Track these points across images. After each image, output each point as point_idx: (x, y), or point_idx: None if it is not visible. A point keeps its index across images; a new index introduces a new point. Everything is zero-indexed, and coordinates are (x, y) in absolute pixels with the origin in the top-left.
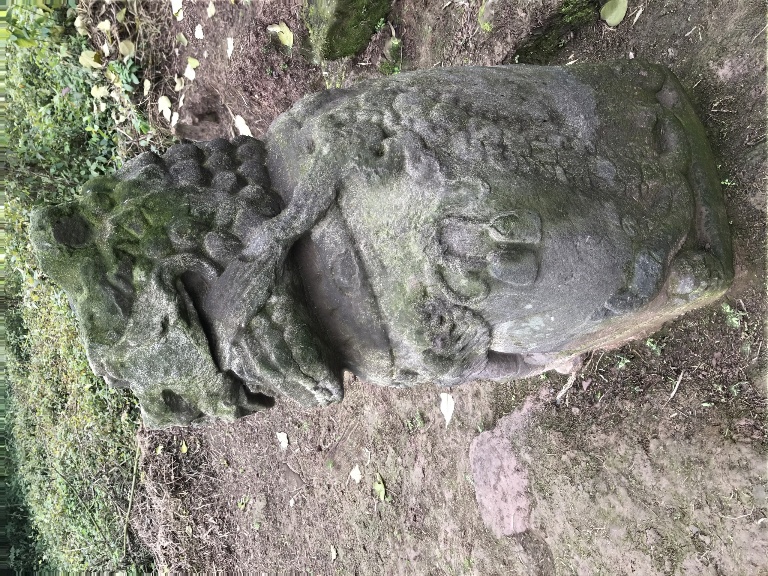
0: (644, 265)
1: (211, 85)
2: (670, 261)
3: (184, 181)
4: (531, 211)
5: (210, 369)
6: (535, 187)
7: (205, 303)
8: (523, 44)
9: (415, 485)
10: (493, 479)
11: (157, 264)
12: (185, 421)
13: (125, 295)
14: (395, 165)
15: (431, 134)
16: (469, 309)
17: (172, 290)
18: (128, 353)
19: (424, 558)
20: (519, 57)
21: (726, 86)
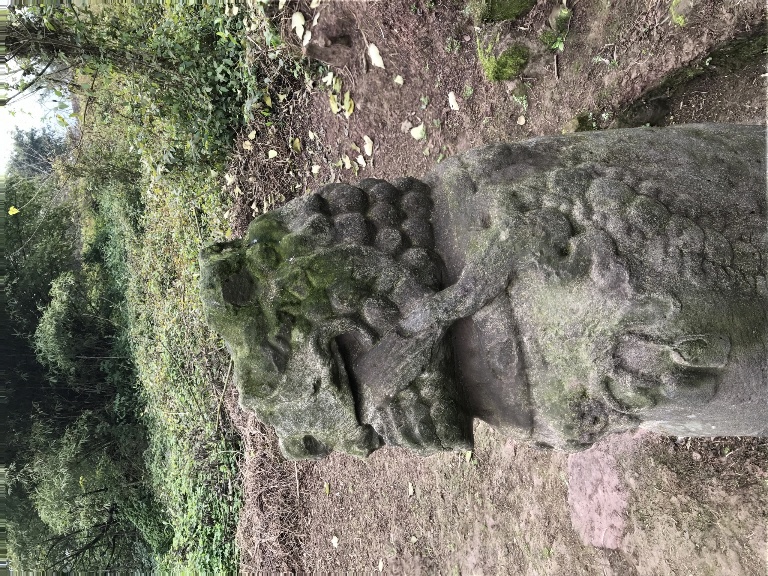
0: None
1: (349, 8)
2: None
3: (349, 238)
4: (722, 335)
5: (352, 424)
6: (731, 305)
7: (356, 366)
8: (720, 47)
9: (504, 460)
10: (590, 489)
11: (316, 327)
12: (320, 458)
13: (282, 353)
14: (580, 270)
15: (625, 237)
16: None
17: (327, 354)
18: (278, 405)
19: (502, 529)
20: (711, 60)
21: None
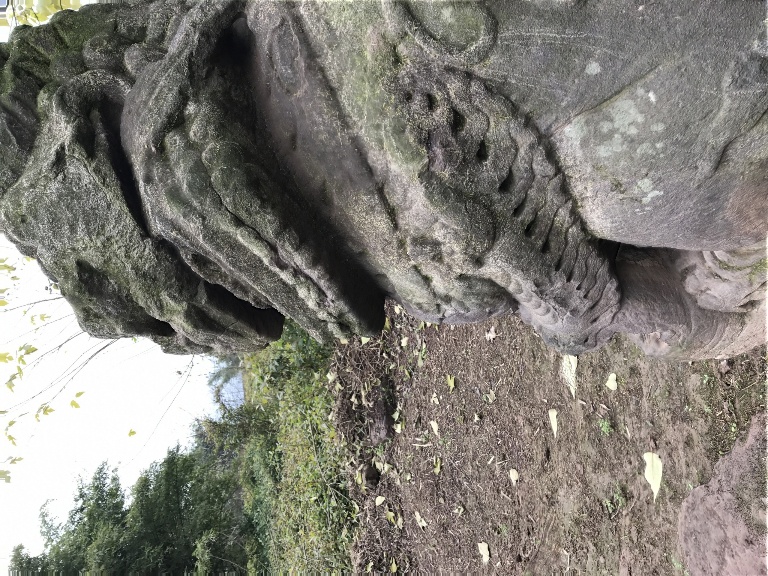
0: None
1: None
2: None
3: None
4: None
5: (130, 229)
6: None
7: (120, 133)
8: None
9: None
10: (715, 563)
11: None
12: (119, 319)
13: (26, 126)
14: None
15: None
16: (476, 78)
17: (75, 112)
18: (25, 200)
19: None
20: None
21: None
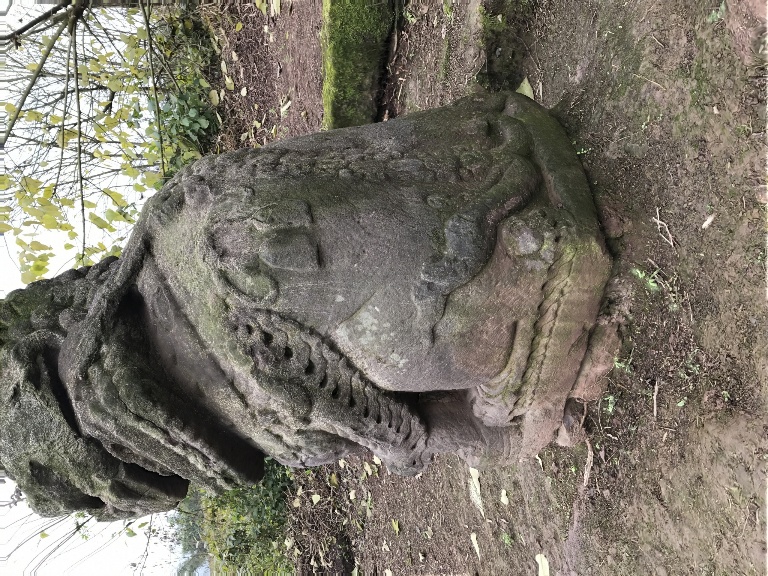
0: (454, 228)
1: None
2: (493, 221)
3: None
4: (295, 199)
5: (67, 433)
6: (306, 184)
7: None
8: None
9: None
10: None
11: None
12: (62, 500)
13: None
14: (175, 200)
15: (209, 171)
16: (274, 312)
17: (26, 360)
18: None
19: None
20: None
21: (580, 85)
